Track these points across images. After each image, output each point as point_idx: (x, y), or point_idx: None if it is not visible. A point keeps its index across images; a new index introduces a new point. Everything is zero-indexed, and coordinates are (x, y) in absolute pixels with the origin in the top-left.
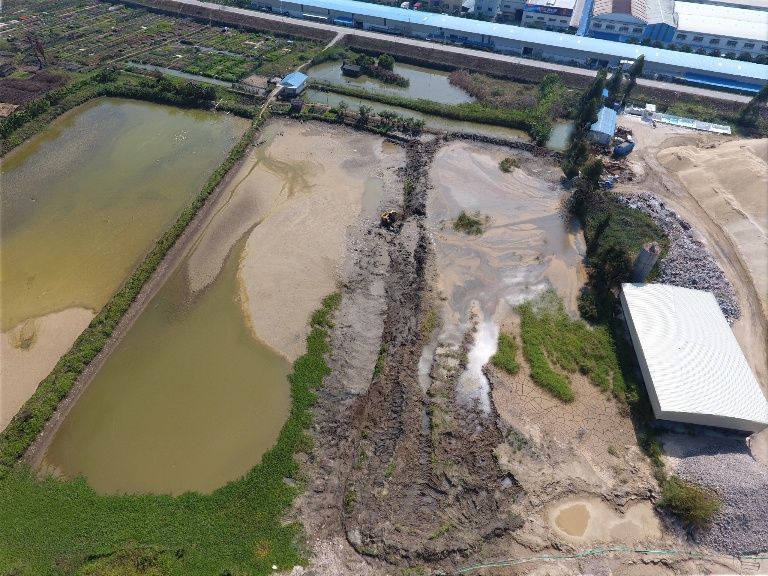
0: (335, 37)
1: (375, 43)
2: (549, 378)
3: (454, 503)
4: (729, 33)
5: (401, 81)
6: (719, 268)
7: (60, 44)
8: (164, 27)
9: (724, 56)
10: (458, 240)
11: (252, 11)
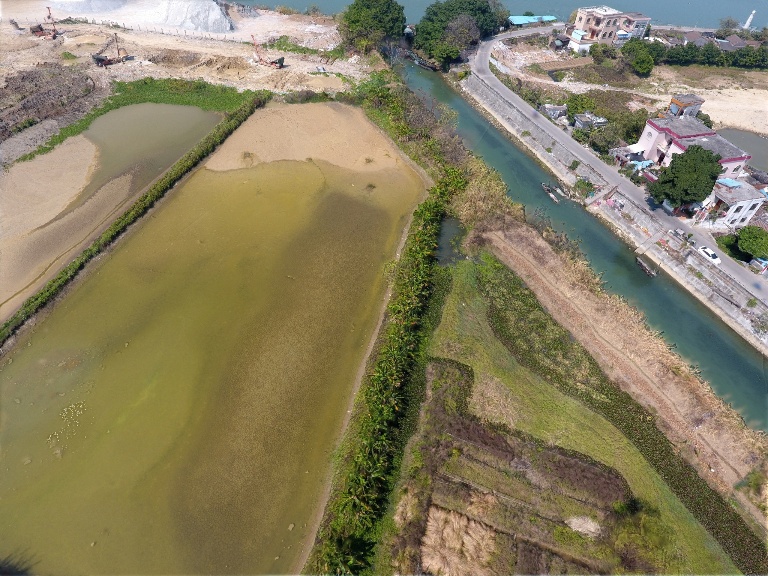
0: None
1: None
2: None
3: None
4: None
5: None
6: None
7: None
8: None
9: None
10: None
11: None
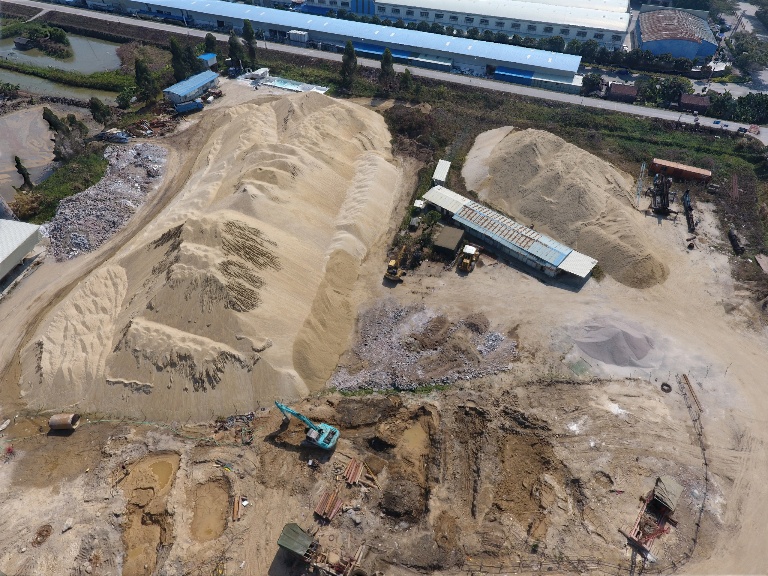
0: (38, 14)
1: (71, 19)
2: None
3: None
4: (420, 4)
5: (61, 52)
6: (132, 209)
7: None
8: None
9: (406, 26)
10: None
11: None
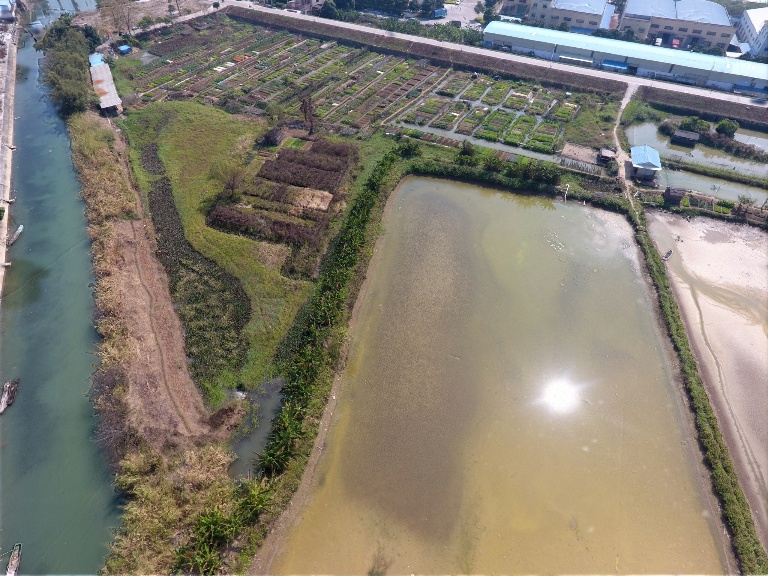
0: (627, 89)
1: (683, 98)
2: None
3: None
4: None
5: (760, 155)
6: None
7: (306, 97)
8: (402, 72)
9: None
10: None
11: (499, 52)
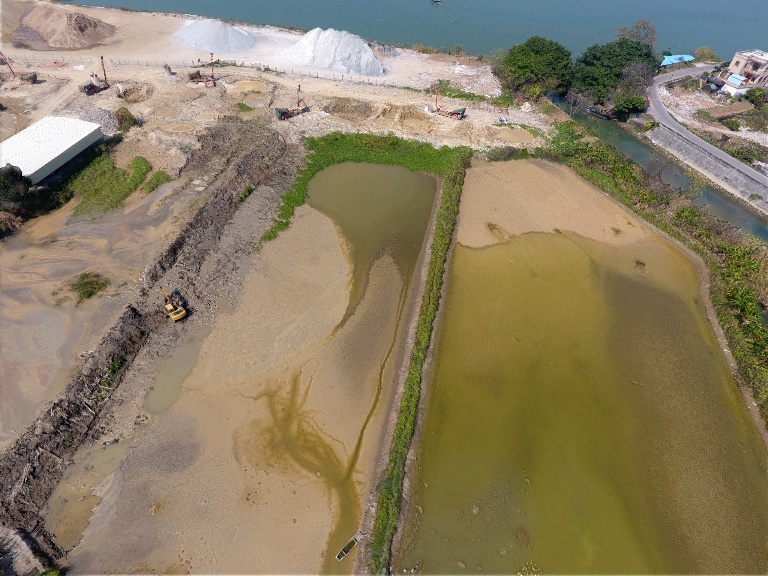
0: None
1: None
2: (141, 164)
3: None
4: None
5: None
6: None
7: None
8: None
9: None
10: (117, 268)
11: None
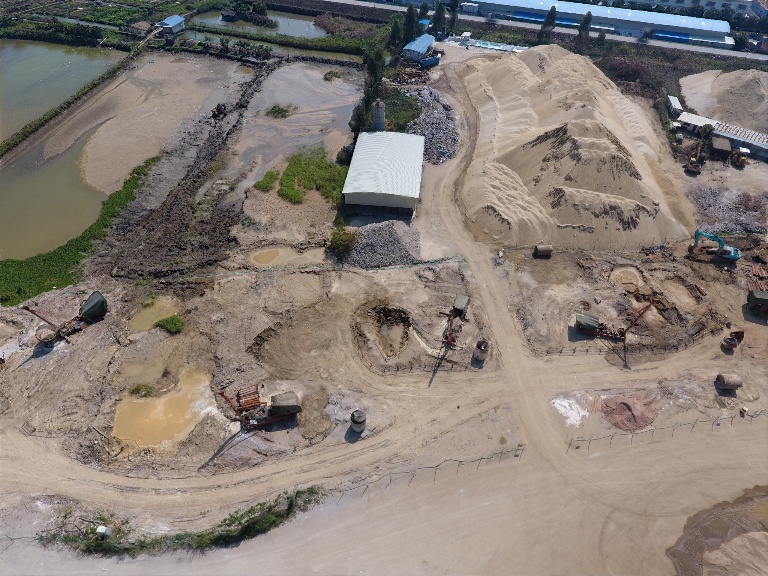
0: None
1: None
2: (288, 191)
3: (189, 253)
4: None
5: (270, 23)
6: (456, 131)
7: None
8: None
9: None
10: (265, 122)
11: None
